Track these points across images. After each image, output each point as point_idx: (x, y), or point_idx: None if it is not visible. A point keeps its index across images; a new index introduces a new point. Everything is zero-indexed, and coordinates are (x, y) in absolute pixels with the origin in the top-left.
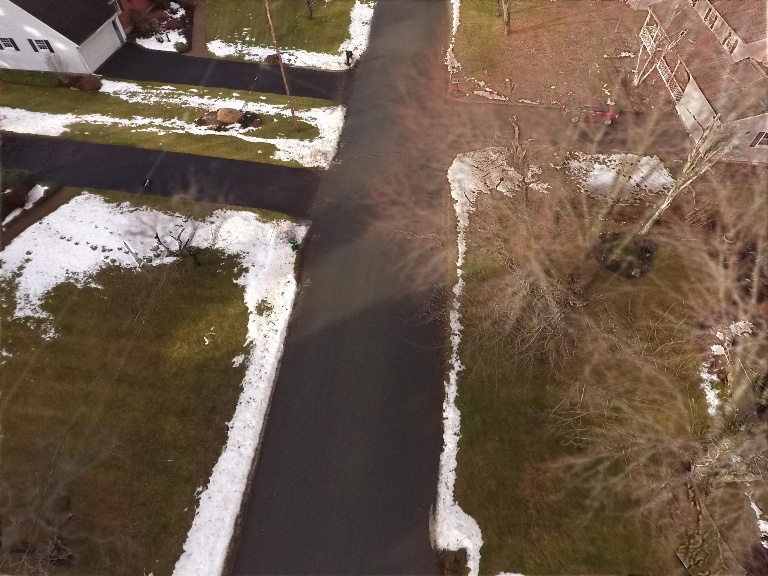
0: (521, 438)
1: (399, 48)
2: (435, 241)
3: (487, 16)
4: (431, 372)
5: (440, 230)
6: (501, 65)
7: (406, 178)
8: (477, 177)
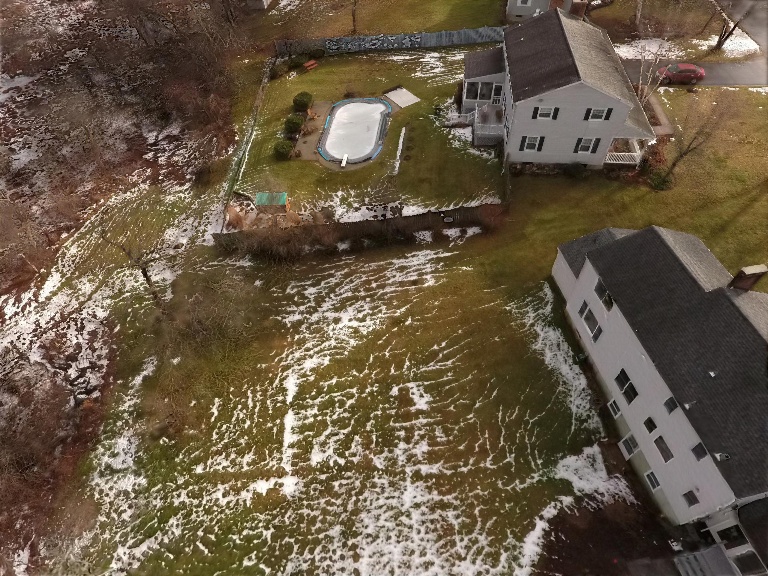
0: None
1: None
2: None
3: None
4: None
5: None
6: None
7: None
8: None
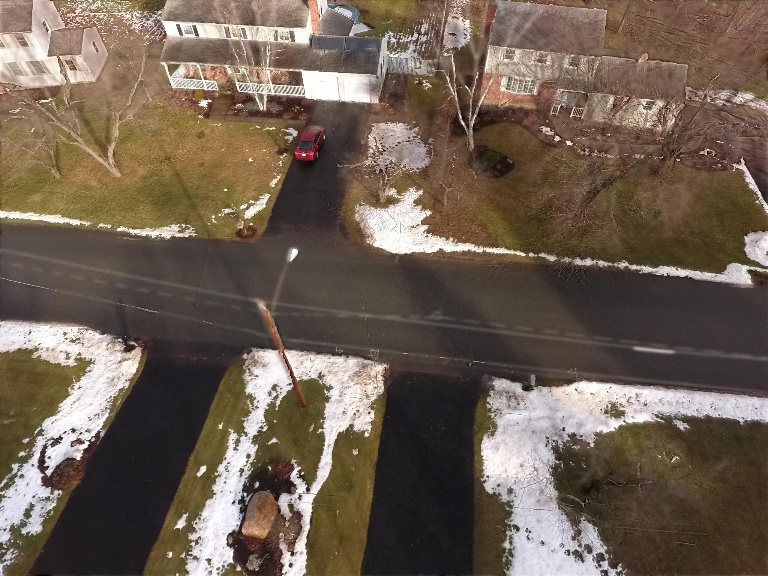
0: (666, 237)
1: (104, 284)
2: (496, 269)
3: (55, 187)
4: (634, 280)
5: (481, 265)
6: (192, 190)
7: (407, 287)
8: (405, 231)
